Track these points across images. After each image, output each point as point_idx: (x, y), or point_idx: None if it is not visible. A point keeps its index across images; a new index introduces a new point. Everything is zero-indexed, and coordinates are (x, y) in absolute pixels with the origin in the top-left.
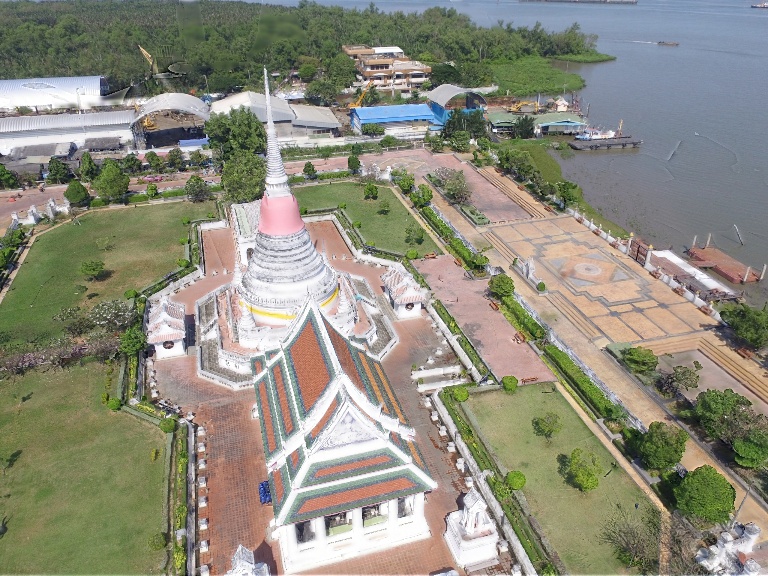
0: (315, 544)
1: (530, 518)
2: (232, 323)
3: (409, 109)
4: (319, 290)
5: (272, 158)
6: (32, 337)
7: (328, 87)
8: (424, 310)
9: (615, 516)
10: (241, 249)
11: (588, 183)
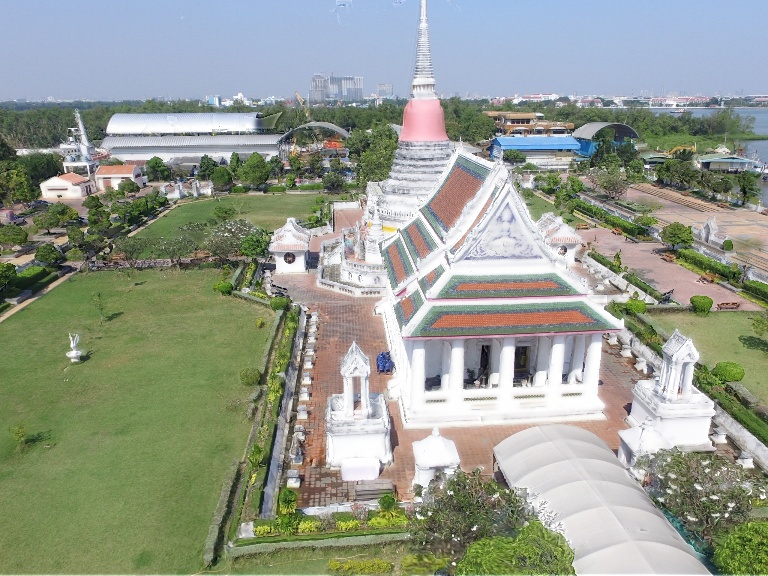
0: (447, 393)
1: (759, 406)
2: (360, 240)
3: (553, 139)
4: None
5: (422, 55)
6: (157, 253)
7: (468, 135)
8: (578, 262)
9: None
10: None
11: (767, 198)
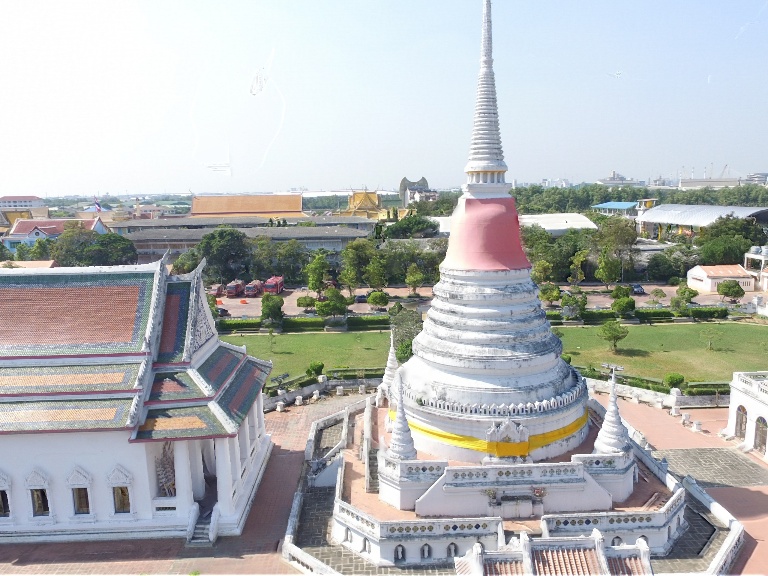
0: None
1: None
2: None
3: None
4: (419, 392)
5: None
6: None
7: None
8: None
9: None
10: (732, 399)
11: None
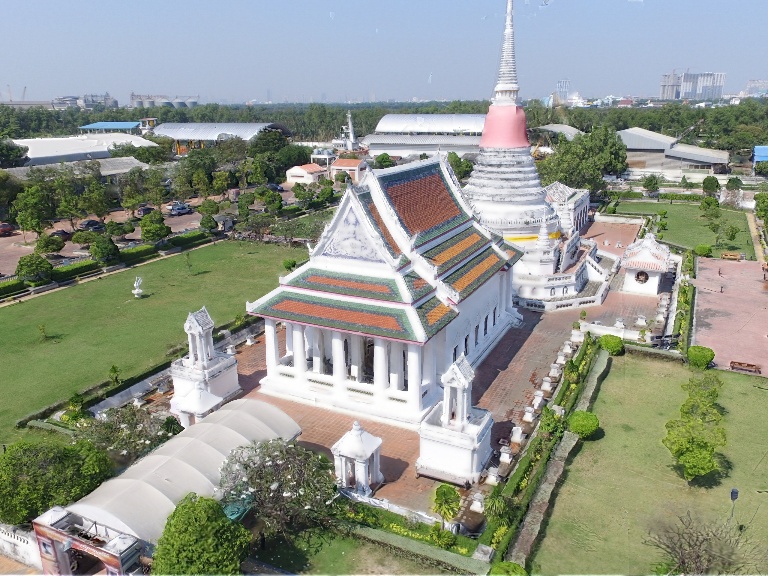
0: (294, 370)
1: None
2: None
3: None
4: (520, 219)
5: (503, 61)
6: None
7: (747, 142)
8: (668, 293)
9: (718, 532)
10: None
11: None
